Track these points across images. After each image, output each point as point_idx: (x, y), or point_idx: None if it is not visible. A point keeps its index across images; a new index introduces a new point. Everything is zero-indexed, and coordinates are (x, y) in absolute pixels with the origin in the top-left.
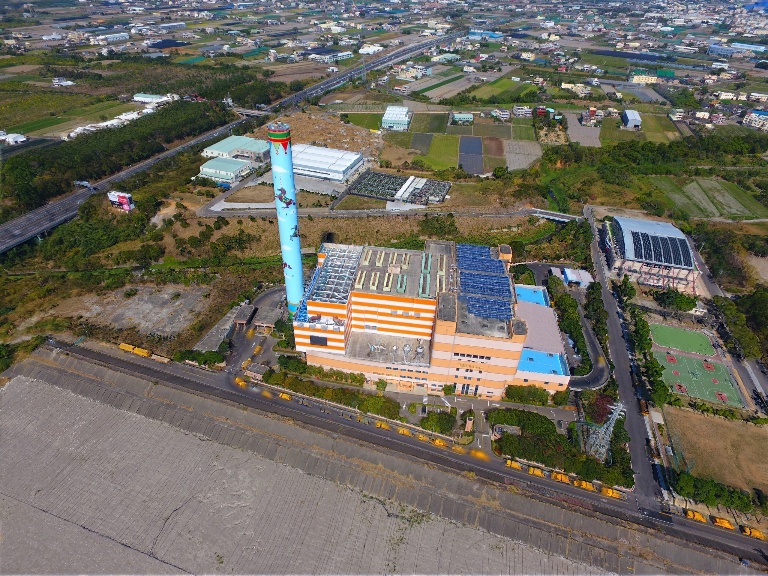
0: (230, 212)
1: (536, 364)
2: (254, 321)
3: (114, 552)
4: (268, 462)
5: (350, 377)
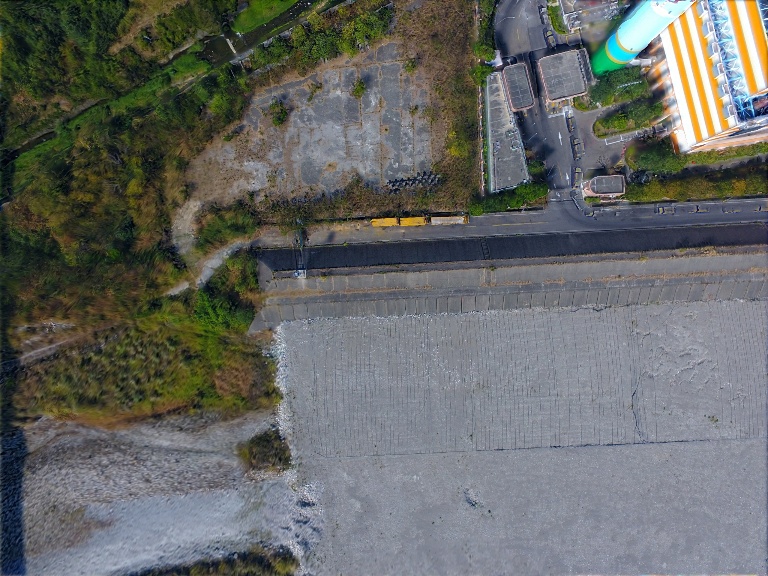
0: None
1: None
2: (548, 98)
3: (606, 454)
4: (697, 305)
5: (763, 151)
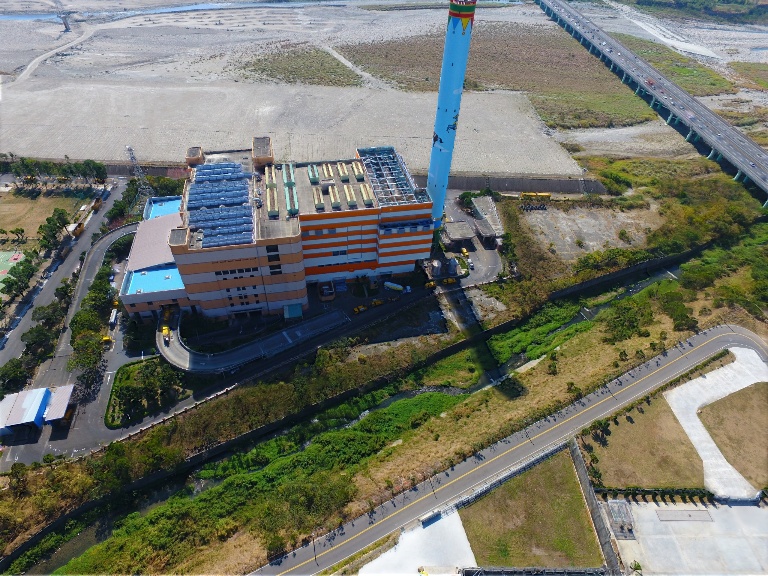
0: (711, 352)
1: (177, 206)
2: None
3: None
4: None
5: None
